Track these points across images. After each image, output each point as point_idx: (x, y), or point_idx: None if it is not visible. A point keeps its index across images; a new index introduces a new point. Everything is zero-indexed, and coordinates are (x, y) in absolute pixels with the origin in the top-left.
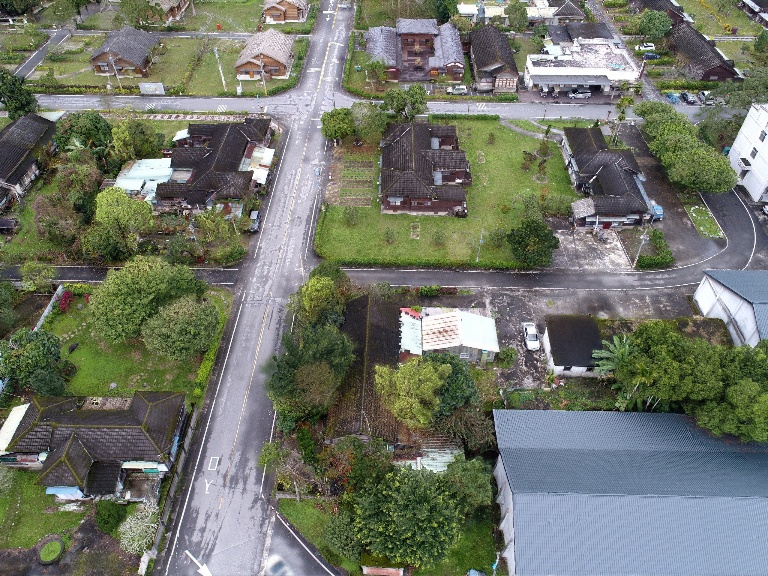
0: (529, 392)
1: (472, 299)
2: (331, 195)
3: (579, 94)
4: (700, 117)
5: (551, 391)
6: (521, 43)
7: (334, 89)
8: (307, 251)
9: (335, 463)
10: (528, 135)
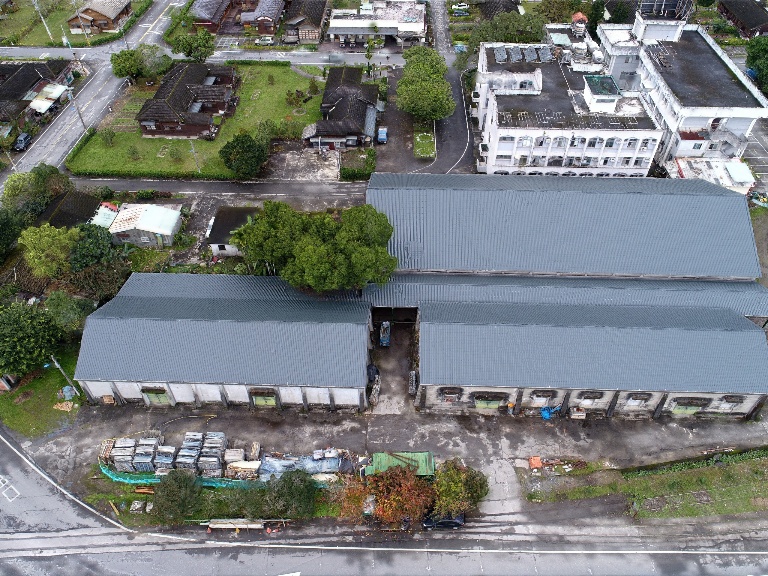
0: (188, 267)
1: (182, 201)
2: (105, 124)
3: None
4: None
5: (207, 266)
6: (348, 3)
7: (154, 41)
8: (60, 165)
9: None
10: (309, 78)
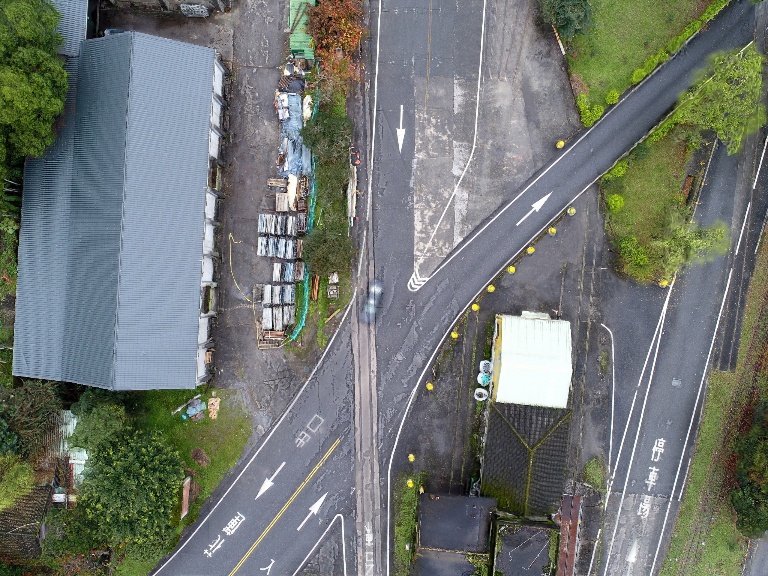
0: None
1: None
2: None
3: None
4: None
5: None
6: None
7: None
8: None
9: (73, 572)
10: None
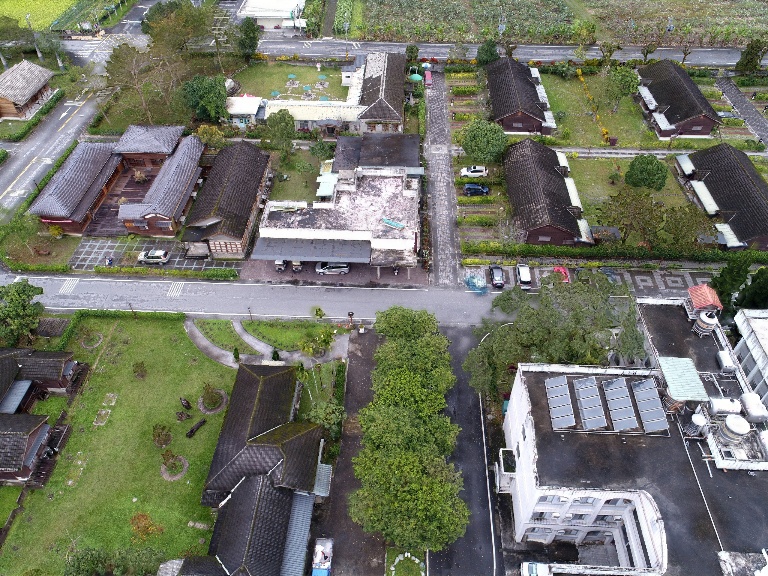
0: None
1: None
2: None
3: (329, 269)
4: (501, 318)
5: None
6: None
7: None
8: None
9: None
10: (212, 356)
